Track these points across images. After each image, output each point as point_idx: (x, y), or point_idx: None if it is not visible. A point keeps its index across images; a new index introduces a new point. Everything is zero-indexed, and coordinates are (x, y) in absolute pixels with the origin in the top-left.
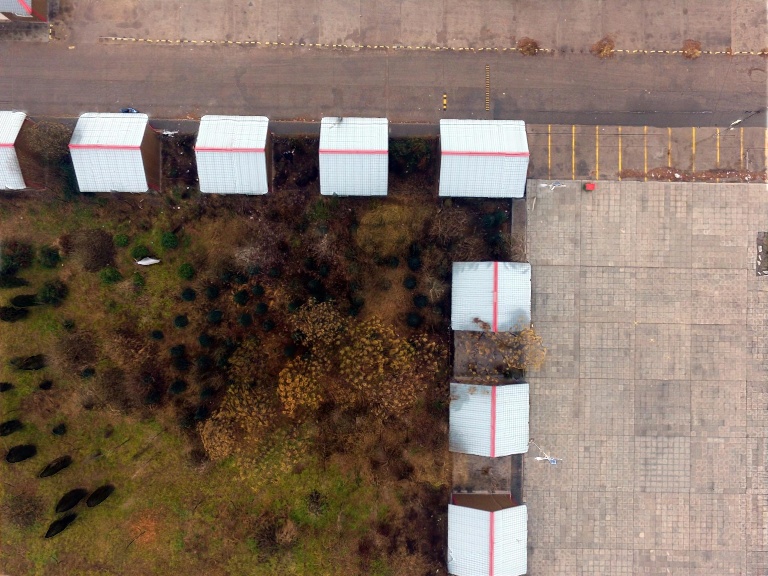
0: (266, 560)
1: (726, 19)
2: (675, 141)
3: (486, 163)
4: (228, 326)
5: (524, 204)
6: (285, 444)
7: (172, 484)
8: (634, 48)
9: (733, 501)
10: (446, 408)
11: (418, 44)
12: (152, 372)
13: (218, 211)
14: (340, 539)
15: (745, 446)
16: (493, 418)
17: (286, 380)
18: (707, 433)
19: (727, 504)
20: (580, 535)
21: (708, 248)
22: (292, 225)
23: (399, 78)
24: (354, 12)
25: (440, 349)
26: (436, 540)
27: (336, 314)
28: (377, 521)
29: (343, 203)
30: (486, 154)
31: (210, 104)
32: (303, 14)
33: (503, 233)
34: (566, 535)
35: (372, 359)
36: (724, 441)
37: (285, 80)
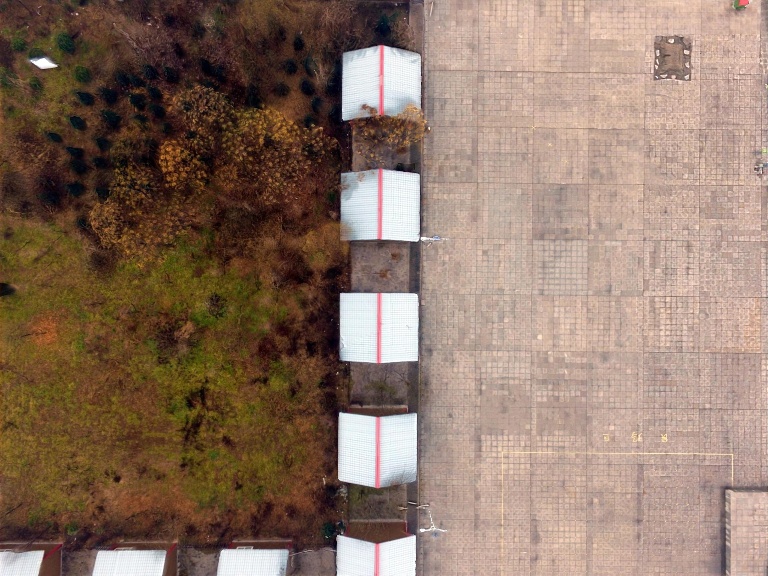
0: (167, 361)
1: None
2: None
3: None
4: None
5: (421, 9)
6: (168, 215)
7: (73, 287)
8: None
9: (630, 303)
10: (338, 199)
11: None
12: (52, 176)
13: (116, 18)
14: (240, 341)
15: (642, 249)
16: (380, 200)
17: (166, 148)
18: (605, 236)
19: (624, 306)
20: (478, 337)
21: (606, 53)
22: (191, 32)
23: None
24: None
25: (331, 140)
26: (336, 343)
27: None
28: (277, 323)
29: None
30: None
31: None
32: None
33: None
34: (464, 337)
35: (253, 130)
36: (621, 244)
37: None
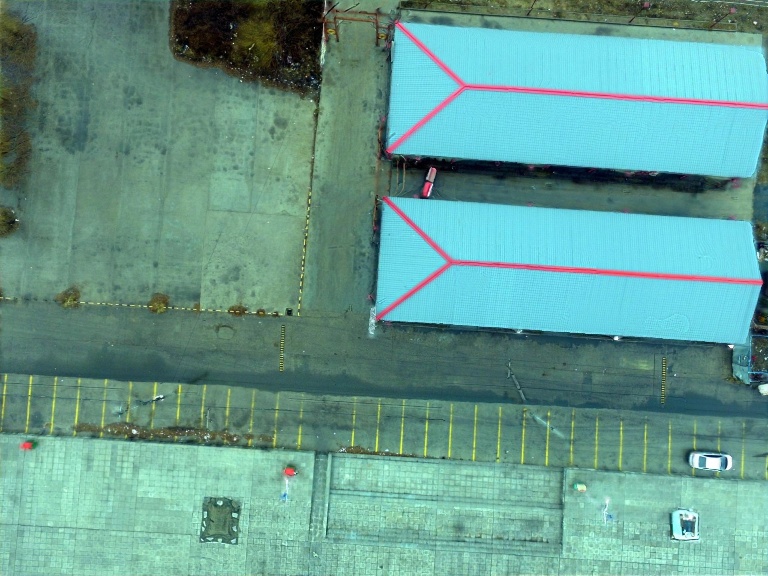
0: None
1: (196, 274)
2: (135, 396)
3: None
4: None
5: None
6: None
7: None
8: (99, 300)
9: None
10: None
11: None
12: None
13: None
14: None
15: None
16: None
17: None
18: None
19: None
20: None
21: (152, 511)
22: None
23: None
24: None
25: None
26: None
27: None
28: None
29: None
30: None
31: None
32: None
33: None
34: None
35: None
36: None
37: None
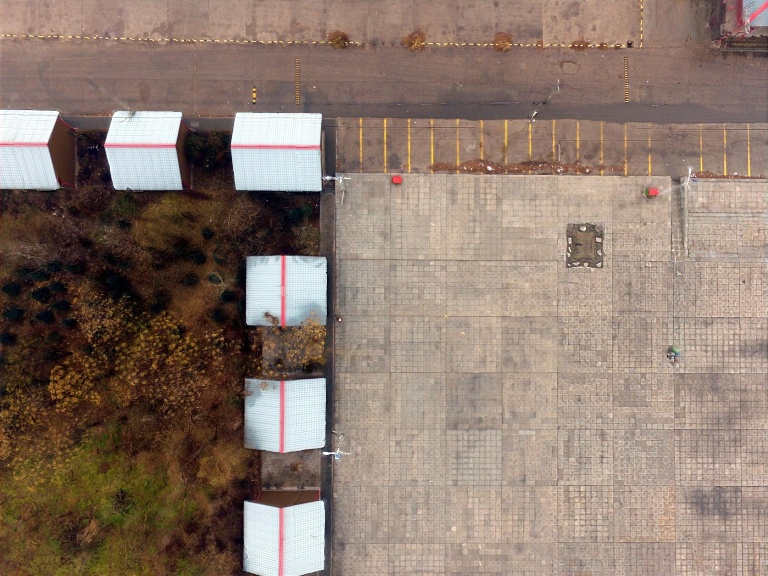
0: (70, 562)
1: (537, 12)
2: (487, 134)
3: (278, 156)
4: (30, 324)
5: (332, 198)
6: (57, 443)
7: None
8: (445, 41)
9: (545, 493)
10: (242, 404)
11: (226, 37)
12: None
13: (20, 208)
14: (146, 539)
15: (556, 438)
16: (281, 413)
17: (54, 378)
18: (518, 425)
19: (539, 496)
20: (391, 530)
21: (518, 240)
22: (97, 221)
23: (207, 72)
24: (161, 5)
25: (235, 344)
26: None
27: (123, 310)
28: (185, 520)
29: (150, 198)
30: (276, 147)
31: (12, 99)
32: (108, 7)
33: (295, 227)
34: (377, 530)
35: (145, 355)
36: (535, 433)
37: (90, 74)
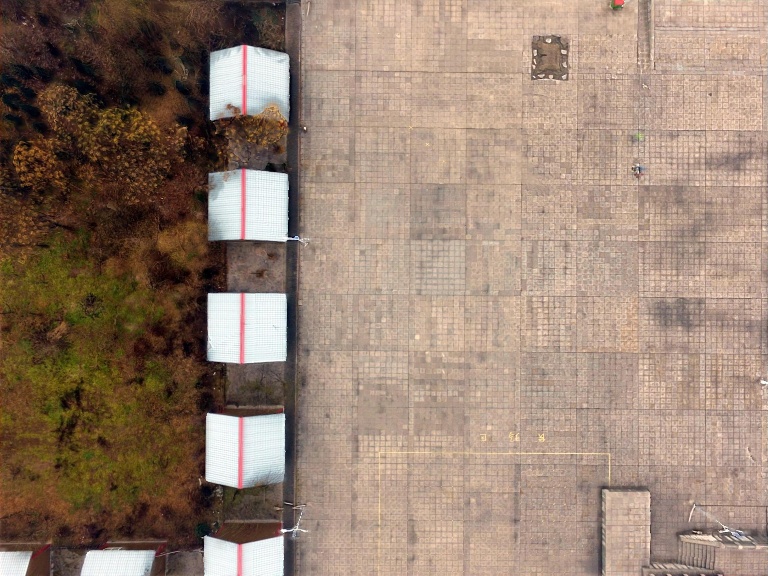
0: (41, 362)
1: None
2: None
3: None
4: None
5: (298, 9)
6: (22, 216)
7: None
8: None
9: (508, 303)
10: (206, 199)
11: None
12: None
13: None
14: (115, 341)
15: (520, 249)
16: (243, 200)
17: None
18: (482, 236)
19: (502, 306)
20: (356, 337)
21: (483, 52)
22: (67, 32)
23: None
24: None
25: (199, 140)
26: None
27: (89, 101)
28: (153, 324)
29: None
30: None
31: None
32: None
33: (257, 21)
34: (342, 337)
35: (107, 130)
36: (499, 244)
37: None
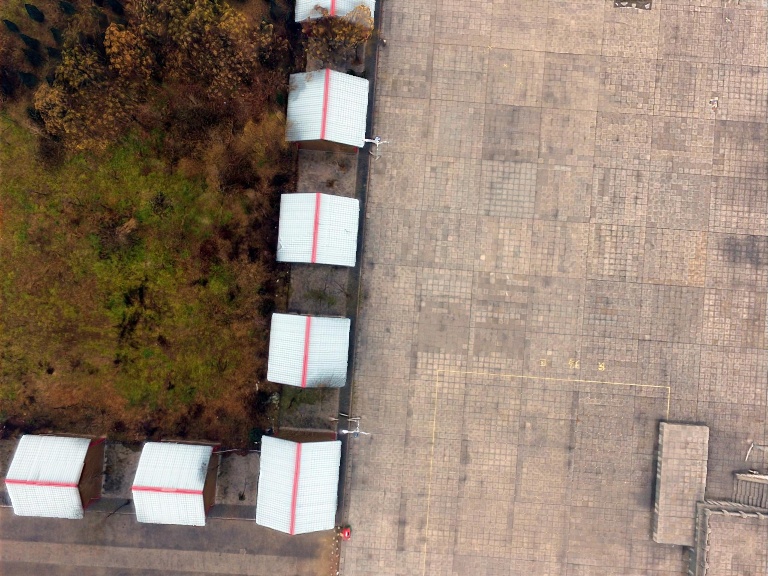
0: (108, 256)
1: None
2: None
3: None
4: None
5: None
6: (108, 96)
7: (19, 177)
8: None
9: (576, 229)
10: (285, 101)
11: None
12: (6, 65)
13: None
14: (182, 241)
15: (592, 176)
16: (325, 100)
17: None
18: (554, 161)
19: (570, 232)
20: (421, 254)
21: None
22: None
23: None
24: None
25: (282, 41)
26: None
27: None
28: (220, 227)
29: None
30: None
31: None
32: None
33: None
34: (407, 253)
35: (198, 16)
36: (571, 169)
37: None
